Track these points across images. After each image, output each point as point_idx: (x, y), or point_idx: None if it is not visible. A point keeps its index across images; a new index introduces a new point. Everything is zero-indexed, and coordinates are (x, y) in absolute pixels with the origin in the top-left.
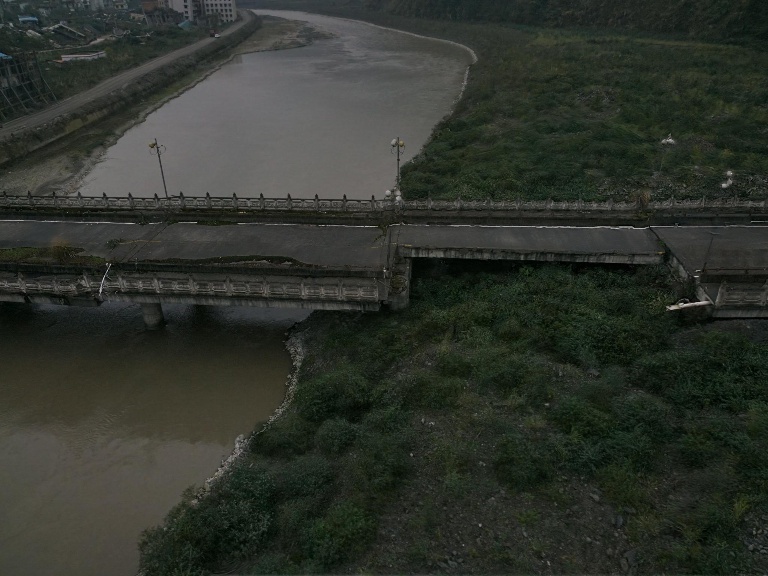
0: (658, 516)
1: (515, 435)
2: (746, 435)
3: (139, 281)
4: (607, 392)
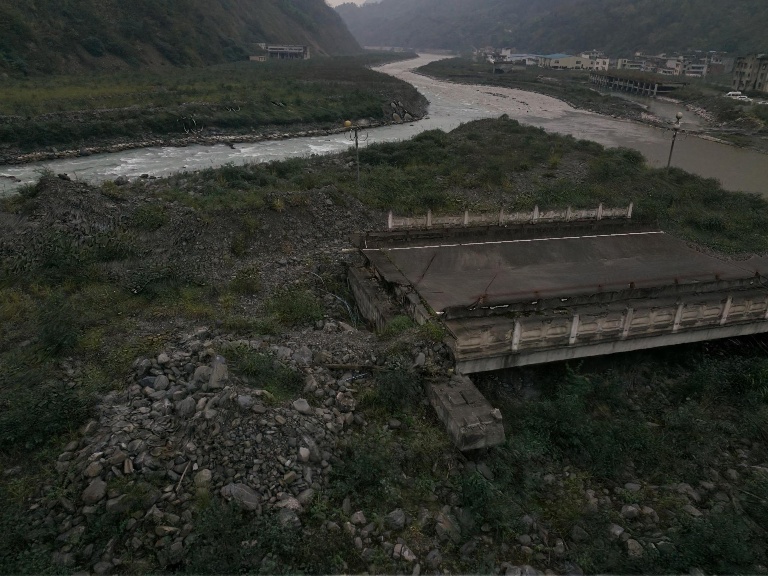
0: (593, 204)
1: (667, 193)
2: (573, 209)
3: None
4: (651, 218)
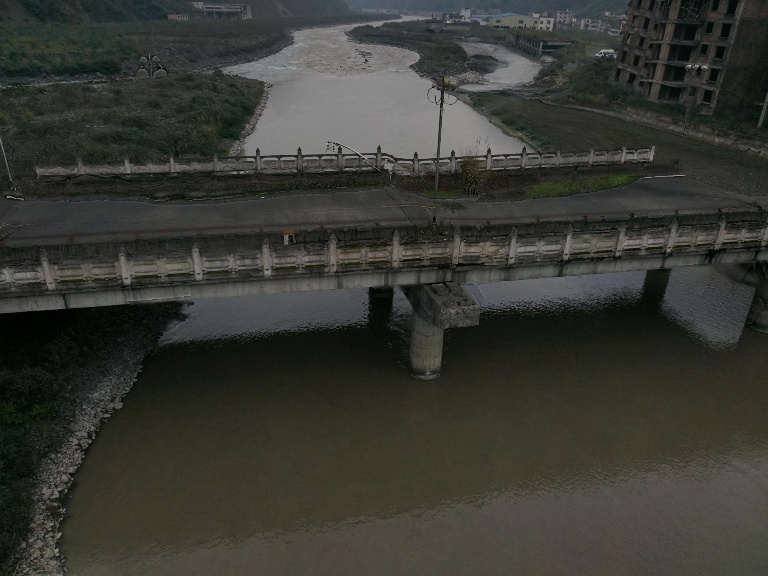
0: None
1: None
2: None
3: (320, 163)
4: None
